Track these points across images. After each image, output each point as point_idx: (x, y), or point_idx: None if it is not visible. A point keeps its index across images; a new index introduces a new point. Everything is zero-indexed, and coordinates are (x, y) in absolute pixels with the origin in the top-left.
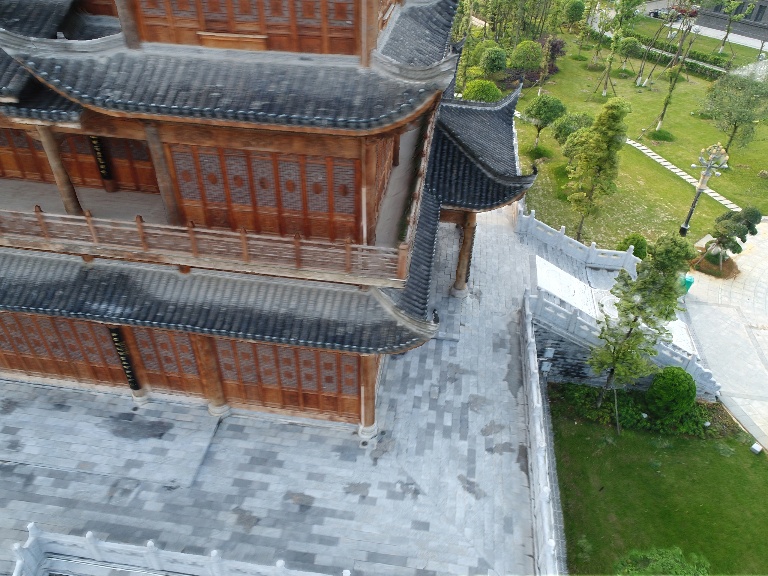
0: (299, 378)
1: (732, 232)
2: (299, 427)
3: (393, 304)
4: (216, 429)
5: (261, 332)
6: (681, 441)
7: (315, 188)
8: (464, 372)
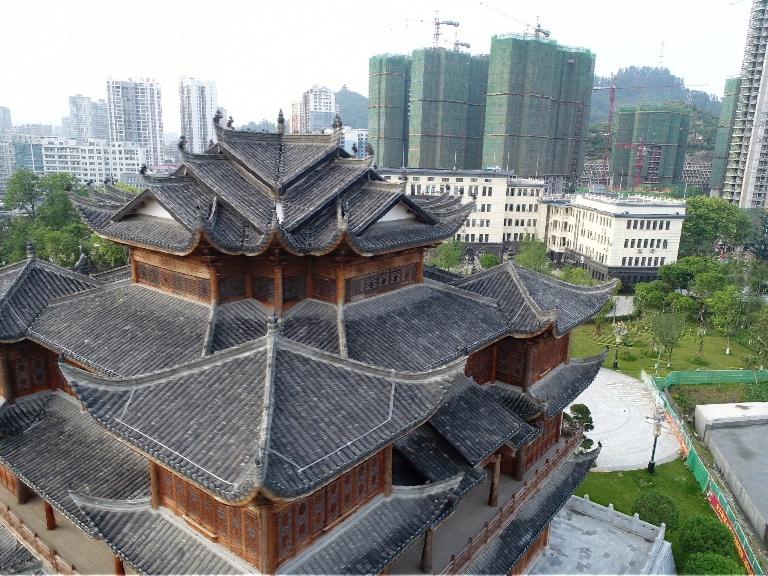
0: None
1: None
2: (532, 573)
3: None
4: None
5: (561, 500)
6: None
7: None
8: None
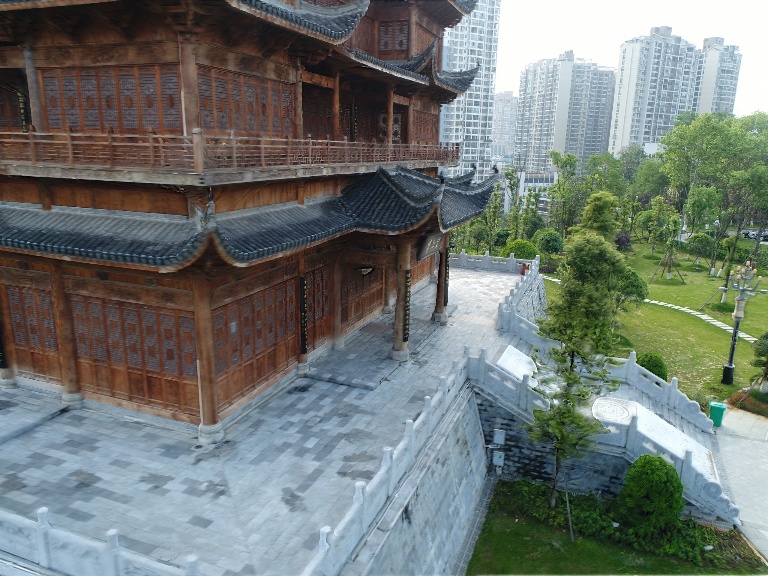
0: (143, 353)
1: (767, 349)
2: (141, 425)
3: (200, 217)
4: (56, 415)
5: None
6: (664, 563)
7: (148, 102)
8: (361, 411)
